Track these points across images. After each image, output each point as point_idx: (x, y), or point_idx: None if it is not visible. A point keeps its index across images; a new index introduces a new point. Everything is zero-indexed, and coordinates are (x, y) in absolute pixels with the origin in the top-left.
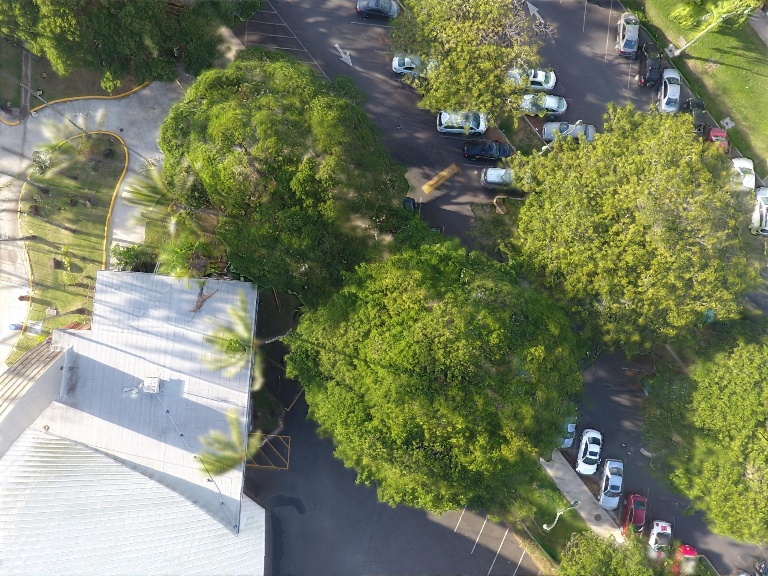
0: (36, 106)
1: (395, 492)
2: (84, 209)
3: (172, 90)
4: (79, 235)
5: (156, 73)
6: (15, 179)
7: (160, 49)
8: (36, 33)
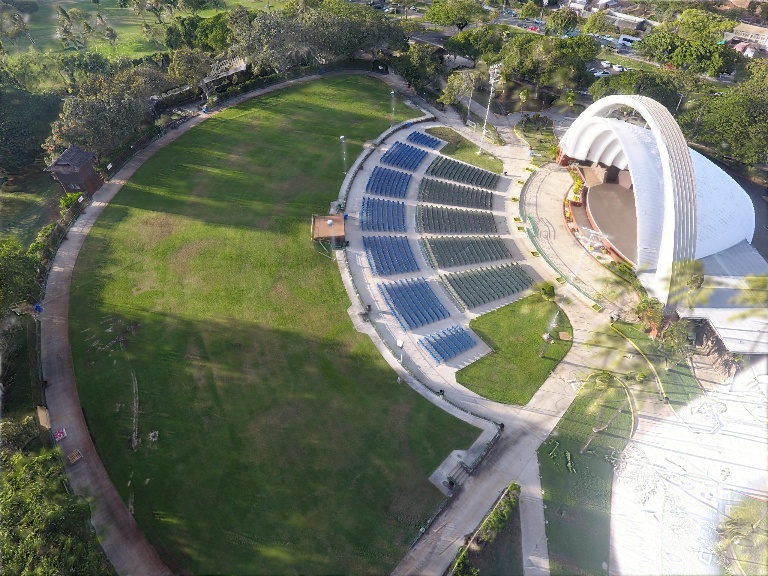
0: (509, 113)
1: (754, 154)
2: (543, 130)
3: (560, 109)
4: (544, 135)
5: (578, 84)
6: (509, 126)
7: (577, 80)
8: (541, 73)
